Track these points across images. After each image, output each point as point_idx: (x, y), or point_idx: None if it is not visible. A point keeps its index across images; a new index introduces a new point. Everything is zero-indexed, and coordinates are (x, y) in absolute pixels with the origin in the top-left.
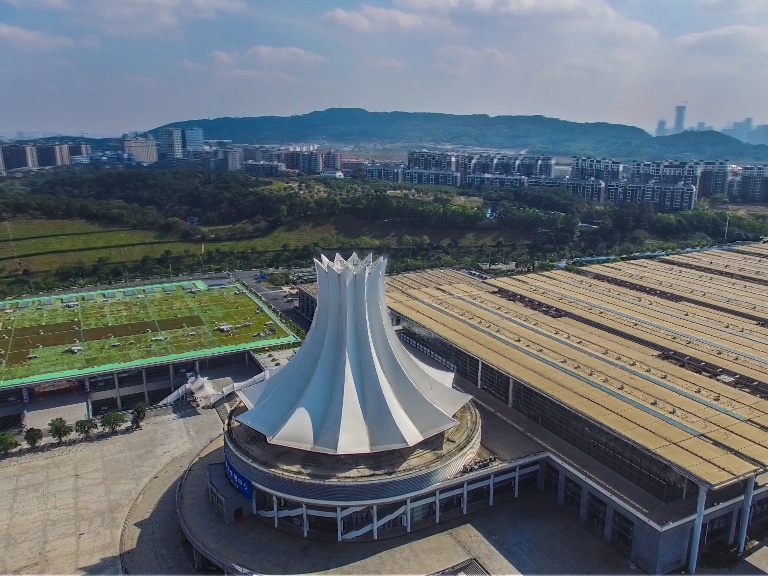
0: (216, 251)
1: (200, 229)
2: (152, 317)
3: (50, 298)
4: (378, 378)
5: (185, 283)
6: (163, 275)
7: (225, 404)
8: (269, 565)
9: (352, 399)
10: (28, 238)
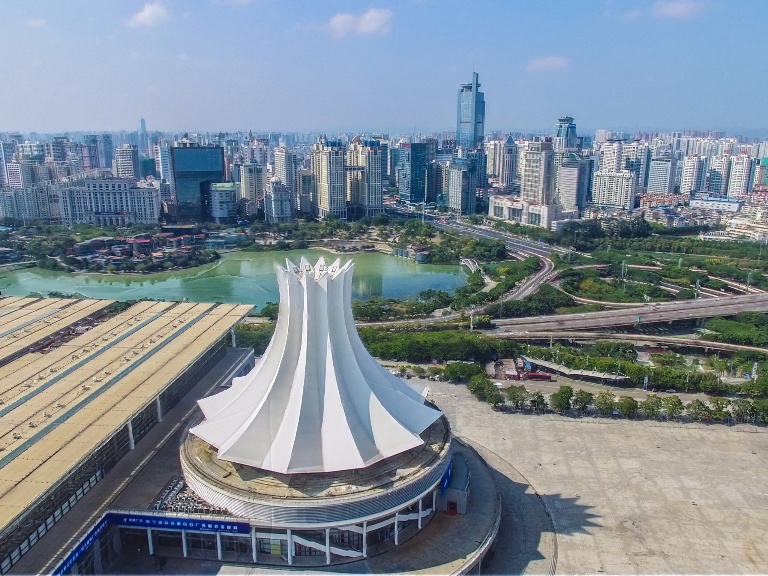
0: None
1: None
2: None
3: None
4: None
5: None
6: None
7: None
8: None
9: None
10: None
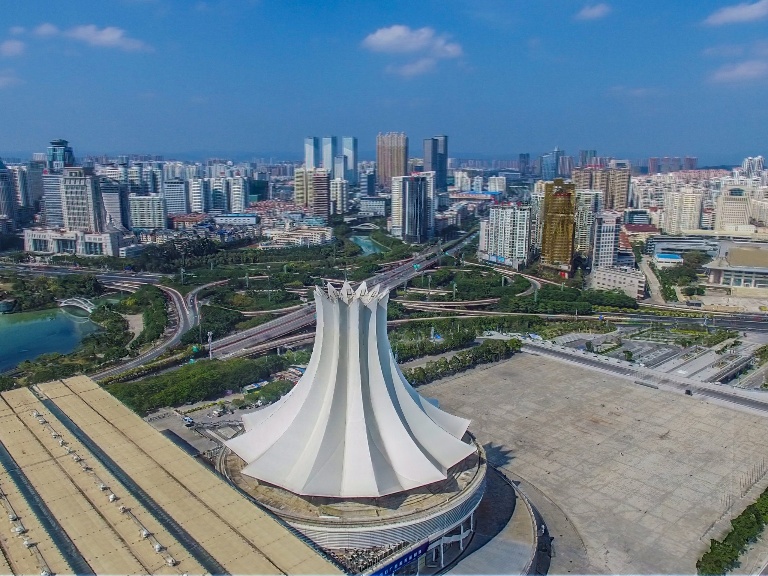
0: None
1: None
2: None
3: None
4: None
5: None
6: None
7: None
8: None
9: None
10: None
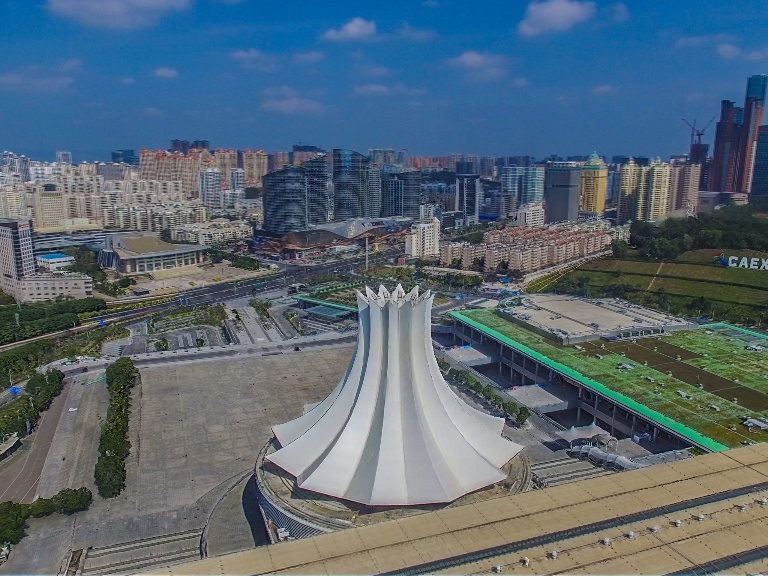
0: None
1: None
2: (750, 382)
3: (766, 338)
4: (332, 405)
5: None
6: None
7: (575, 459)
8: None
9: None
10: None
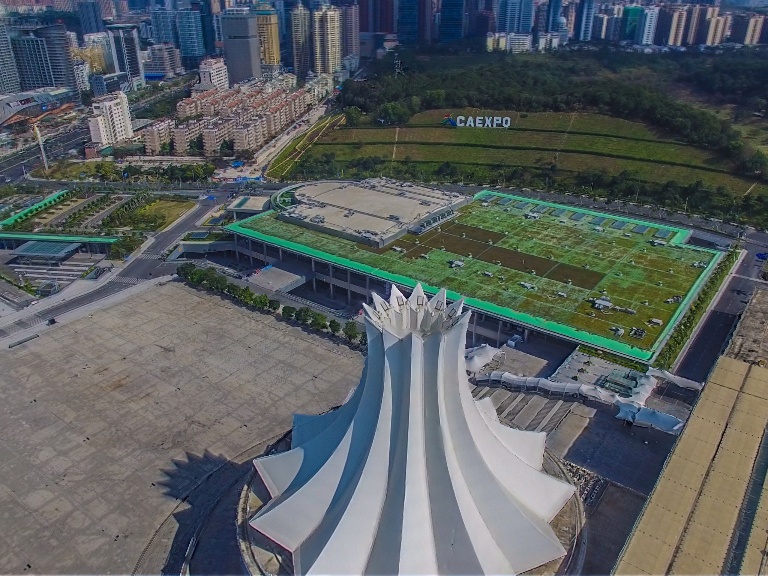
0: (757, 198)
1: (766, 163)
2: (563, 257)
3: (530, 202)
4: (360, 478)
5: (667, 228)
6: (677, 209)
7: (486, 388)
8: (203, 566)
9: (331, 479)
10: (582, 133)
